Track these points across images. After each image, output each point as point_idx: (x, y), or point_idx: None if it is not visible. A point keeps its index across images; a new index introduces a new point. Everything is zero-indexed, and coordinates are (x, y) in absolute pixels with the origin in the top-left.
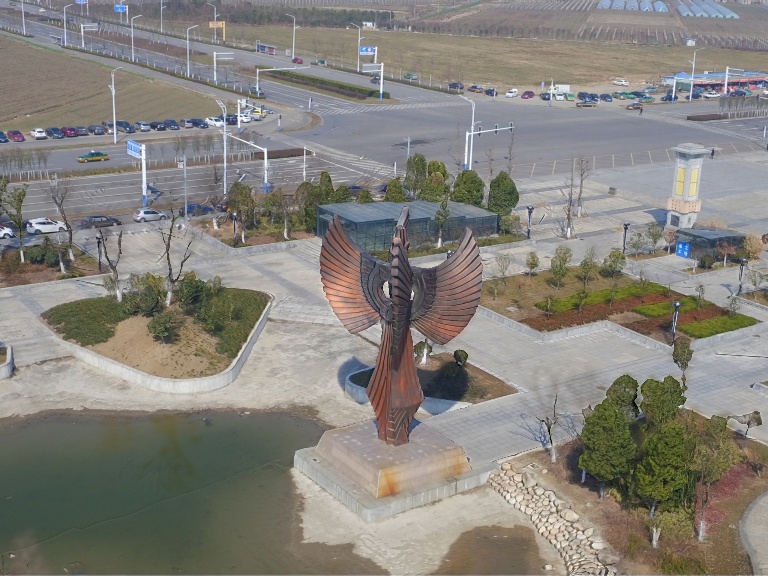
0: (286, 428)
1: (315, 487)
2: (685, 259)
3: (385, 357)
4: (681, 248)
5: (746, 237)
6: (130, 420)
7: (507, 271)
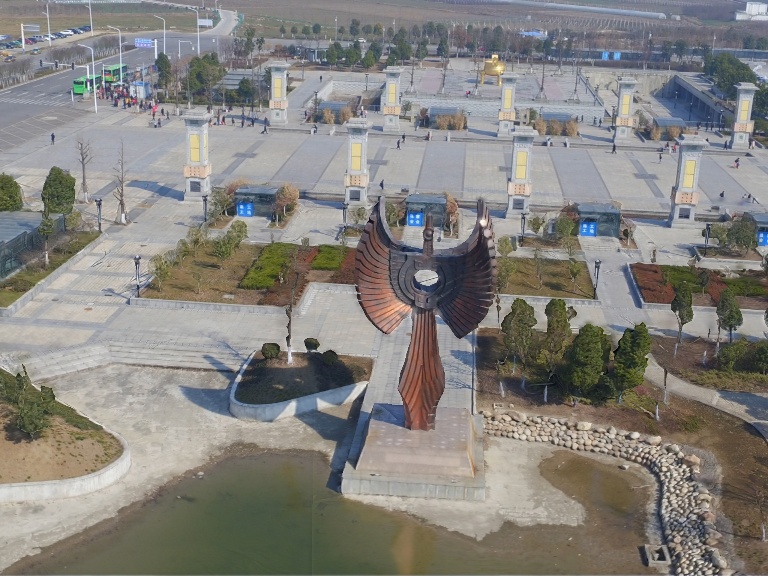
0: (261, 469)
1: (395, 499)
2: (252, 218)
3: (420, 347)
4: (243, 209)
5: (285, 187)
6: (114, 534)
7: (140, 267)
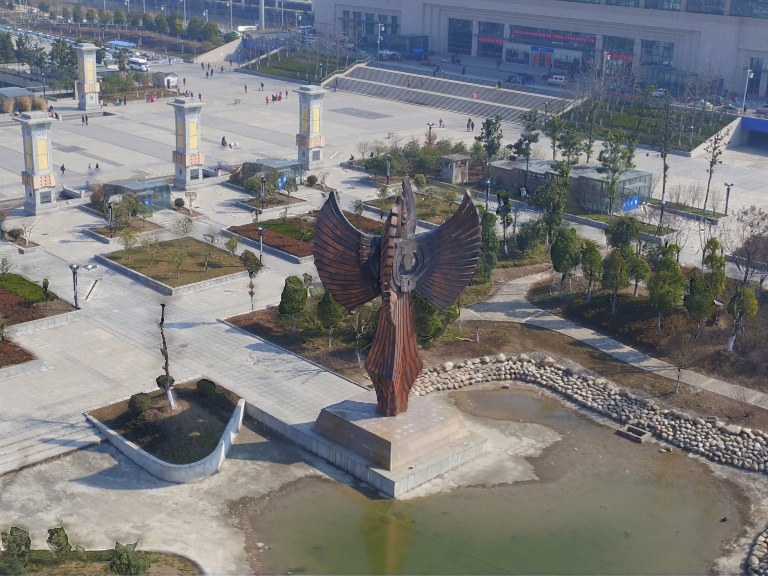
0: (296, 514)
1: (437, 481)
2: None
3: None
4: None
5: None
6: None
7: None
